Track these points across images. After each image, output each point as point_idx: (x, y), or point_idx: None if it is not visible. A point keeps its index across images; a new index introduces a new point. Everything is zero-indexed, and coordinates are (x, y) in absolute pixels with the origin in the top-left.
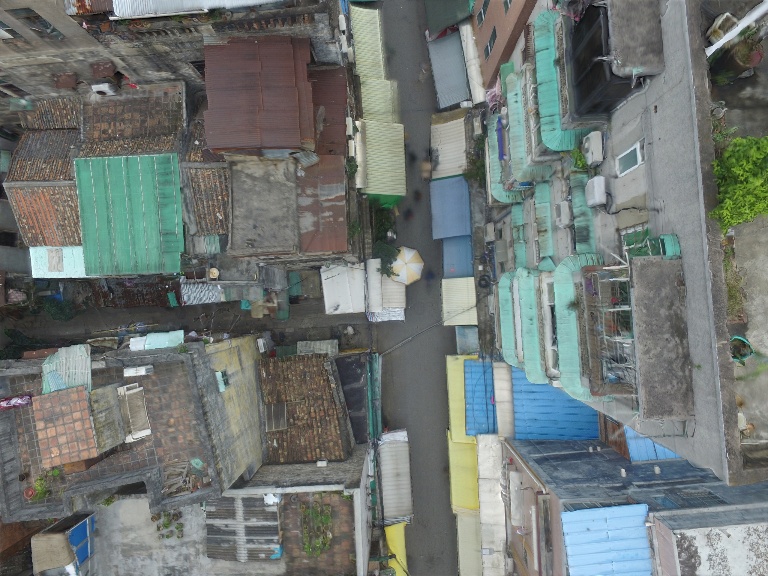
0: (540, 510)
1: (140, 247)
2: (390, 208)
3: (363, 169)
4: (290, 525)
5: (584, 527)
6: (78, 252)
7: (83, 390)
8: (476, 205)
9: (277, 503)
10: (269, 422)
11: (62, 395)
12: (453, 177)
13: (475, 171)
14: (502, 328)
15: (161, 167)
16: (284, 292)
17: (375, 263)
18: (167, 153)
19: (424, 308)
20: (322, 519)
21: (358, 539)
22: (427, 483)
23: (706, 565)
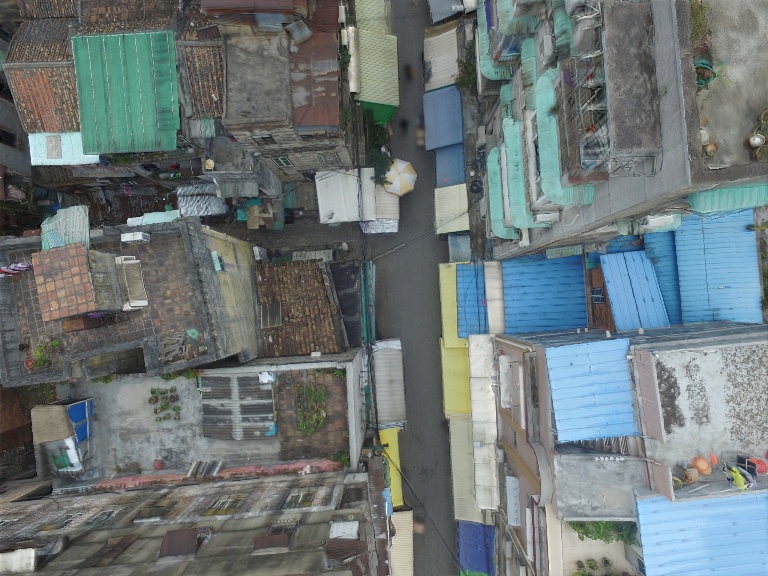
0: (527, 367)
1: (137, 125)
2: (384, 128)
3: (356, 74)
4: (284, 406)
5: (567, 362)
6: (76, 139)
7: (81, 246)
8: (468, 112)
9: (272, 381)
10: (264, 320)
11: (61, 251)
12: (445, 87)
13: (467, 79)
14: (491, 201)
15: (157, 45)
16: (279, 203)
17: (369, 172)
18: (163, 31)
19: (418, 226)
20: (316, 397)
21: (351, 411)
22: (421, 397)
23: (685, 395)
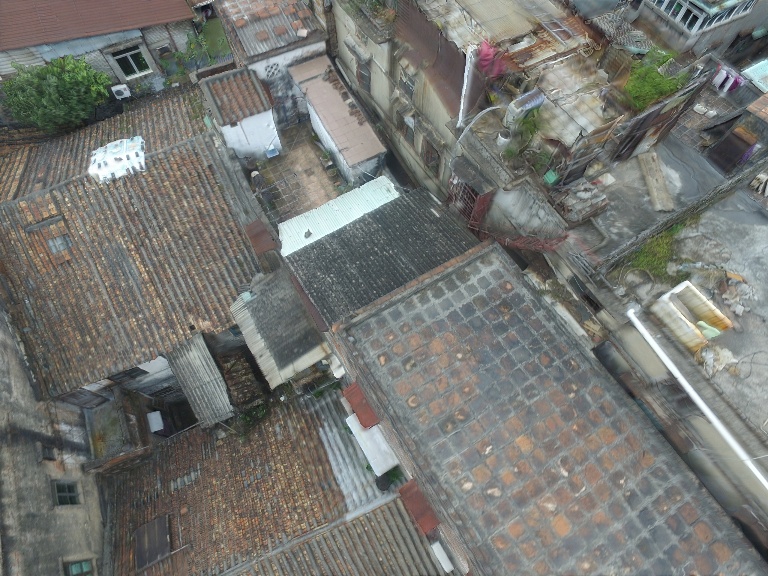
0: None
1: None
2: None
3: None
4: None
5: None
6: None
7: None
8: None
9: None
10: None
11: None
12: None
13: None
14: None
15: None
16: None
17: None
18: None
19: None
20: None
21: None
22: None
23: None
